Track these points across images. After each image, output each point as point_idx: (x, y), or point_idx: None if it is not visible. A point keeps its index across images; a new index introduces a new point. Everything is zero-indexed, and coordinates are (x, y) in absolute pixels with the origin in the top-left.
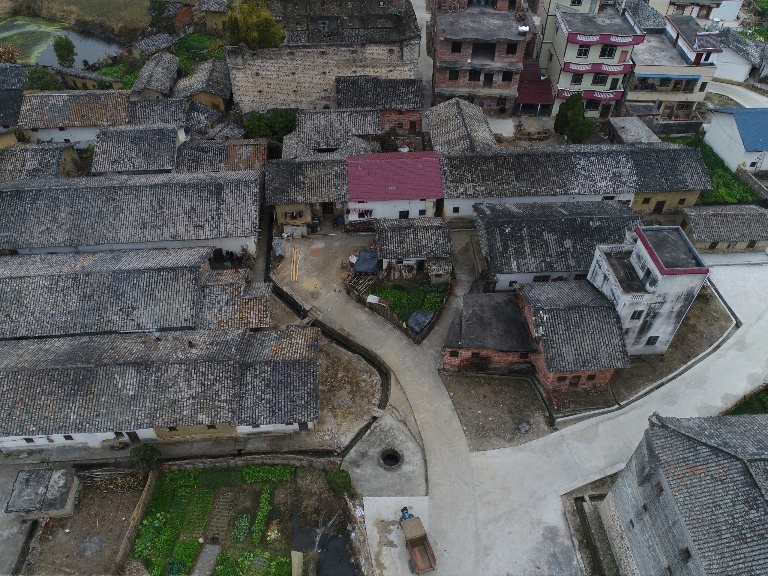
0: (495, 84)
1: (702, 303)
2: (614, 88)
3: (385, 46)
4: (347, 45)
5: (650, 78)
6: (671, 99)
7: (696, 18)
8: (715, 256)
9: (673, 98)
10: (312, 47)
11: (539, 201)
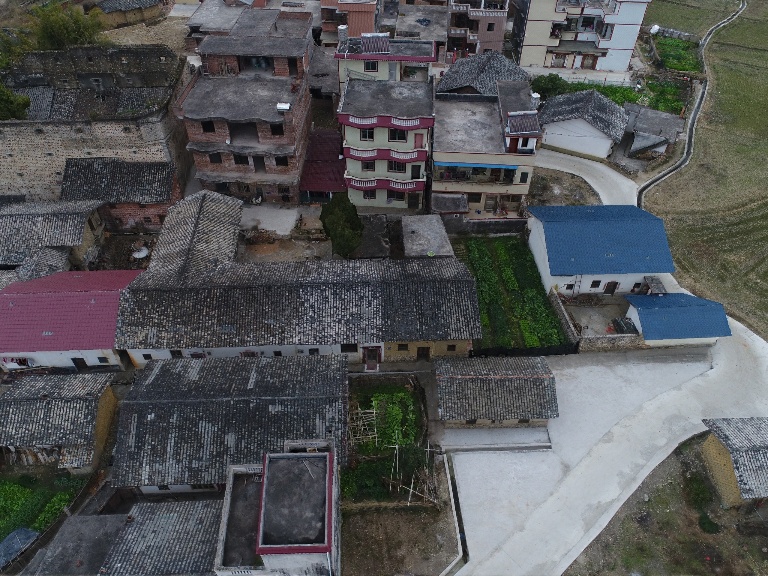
0: (269, 168)
1: (429, 516)
2: (417, 175)
3: (117, 124)
4: (67, 123)
5: (454, 167)
6: (488, 191)
7: (580, 68)
8: (476, 433)
9: (490, 190)
10: (23, 125)
11: (256, 348)
